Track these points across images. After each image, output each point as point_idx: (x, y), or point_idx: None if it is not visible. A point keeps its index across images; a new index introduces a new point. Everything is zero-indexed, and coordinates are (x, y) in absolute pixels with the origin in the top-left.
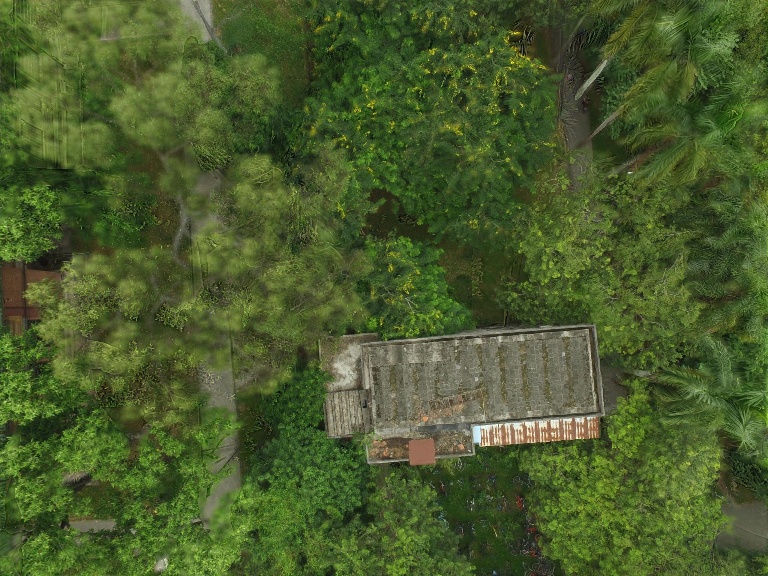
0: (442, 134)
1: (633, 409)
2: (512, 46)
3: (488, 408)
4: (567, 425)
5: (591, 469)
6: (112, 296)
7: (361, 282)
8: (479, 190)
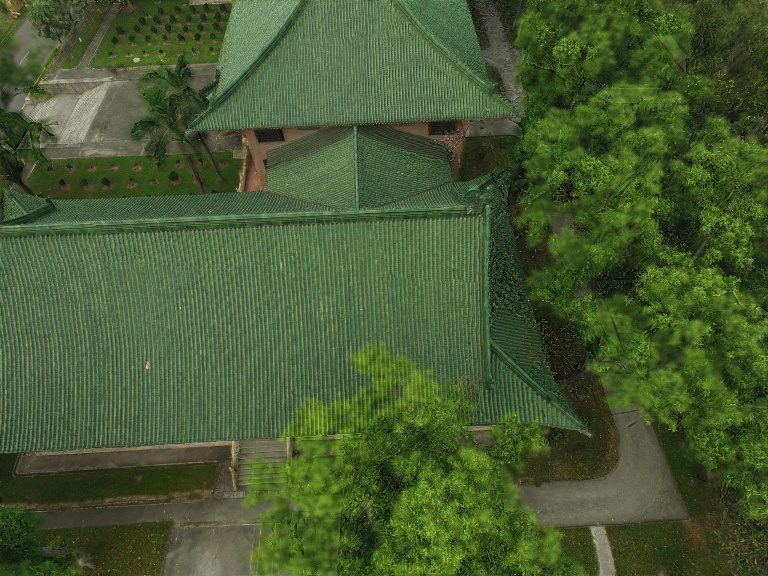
0: None
1: None
2: None
3: None
4: None
5: None
6: None
7: None
8: None
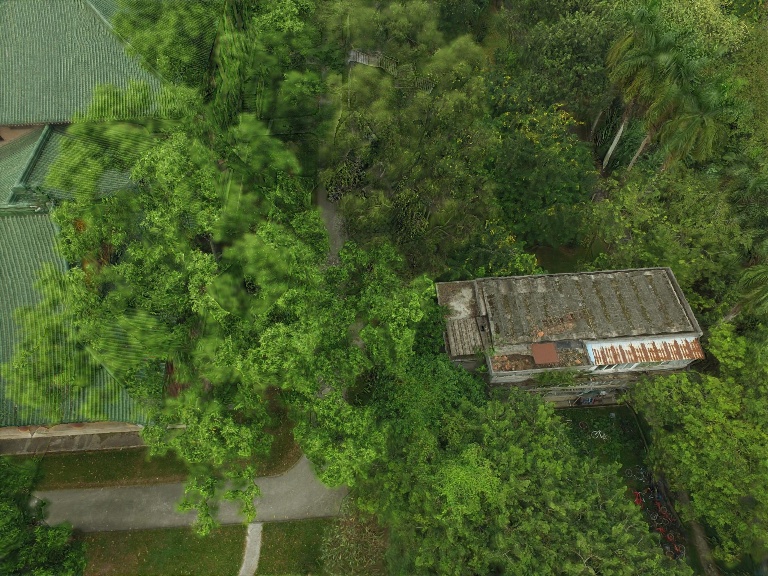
0: (524, 144)
1: (727, 332)
2: (560, 110)
3: (596, 327)
4: (671, 347)
5: (707, 396)
6: (246, 281)
7: (472, 236)
8: (550, 194)
